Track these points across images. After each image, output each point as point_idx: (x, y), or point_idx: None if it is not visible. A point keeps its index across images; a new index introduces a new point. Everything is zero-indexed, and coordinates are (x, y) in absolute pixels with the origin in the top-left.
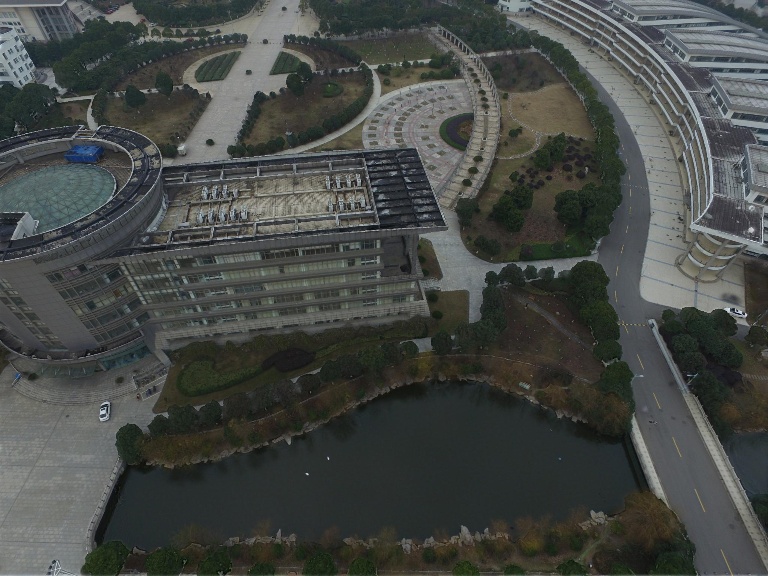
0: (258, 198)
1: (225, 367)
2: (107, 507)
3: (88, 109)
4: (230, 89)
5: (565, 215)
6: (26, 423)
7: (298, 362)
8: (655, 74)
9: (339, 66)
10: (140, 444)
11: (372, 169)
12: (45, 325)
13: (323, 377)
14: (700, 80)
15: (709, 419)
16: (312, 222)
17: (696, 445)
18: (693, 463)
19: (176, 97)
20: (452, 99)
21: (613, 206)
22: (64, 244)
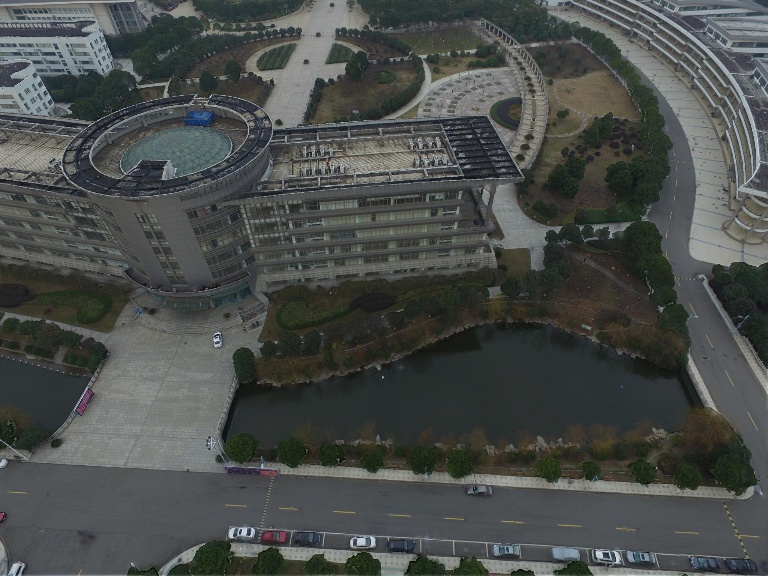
0: (350, 157)
1: (317, 307)
2: (229, 414)
3: (164, 94)
4: (291, 77)
5: (617, 184)
6: (151, 348)
7: (382, 304)
8: (696, 60)
9: (390, 56)
10: (253, 364)
11: (449, 133)
12: (175, 260)
13: (408, 313)
14: (742, 64)
15: (759, 356)
16: (401, 176)
17: (747, 377)
18: (745, 392)
19: (242, 83)
20: (500, 85)
21: (662, 176)
22: (207, 183)
